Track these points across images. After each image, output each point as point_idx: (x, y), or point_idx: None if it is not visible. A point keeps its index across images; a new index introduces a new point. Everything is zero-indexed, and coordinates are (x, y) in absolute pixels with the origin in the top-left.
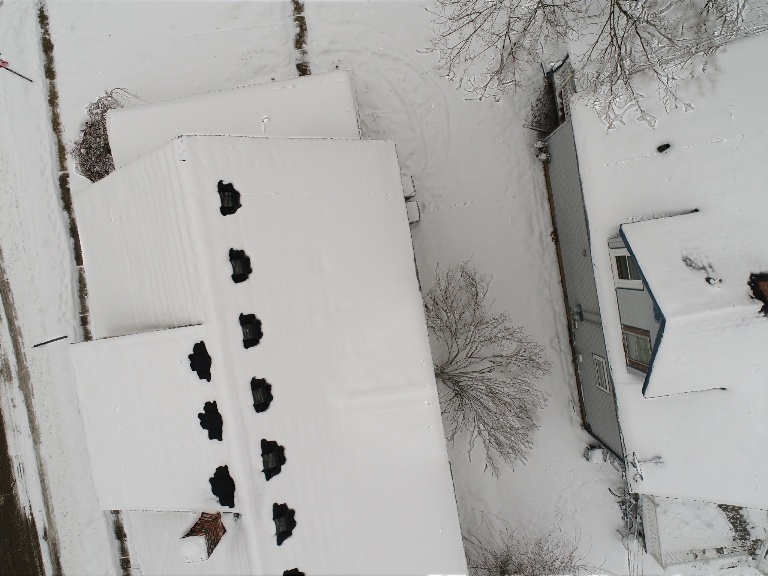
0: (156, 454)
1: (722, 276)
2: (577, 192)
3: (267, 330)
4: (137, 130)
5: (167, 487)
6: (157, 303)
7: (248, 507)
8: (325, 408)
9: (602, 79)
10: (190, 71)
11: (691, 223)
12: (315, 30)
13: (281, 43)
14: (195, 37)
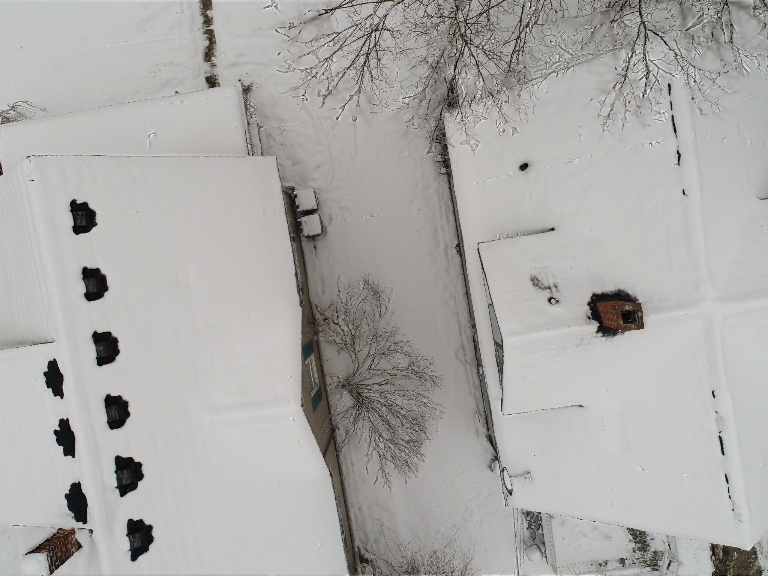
0: (18, 470)
1: (564, 296)
2: None
3: (124, 347)
4: (25, 145)
5: (28, 502)
6: (22, 320)
7: (98, 523)
8: (189, 424)
9: None
10: (100, 84)
11: (544, 242)
12: (223, 43)
13: (190, 56)
14: (104, 50)
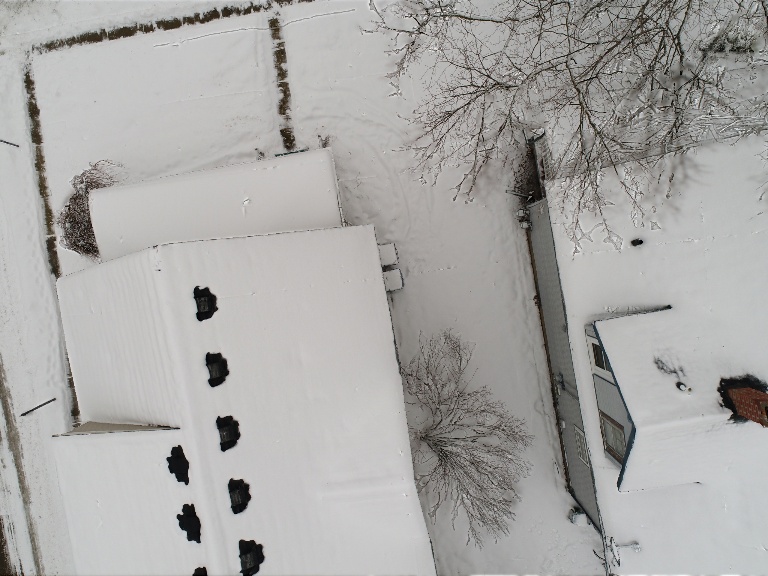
0: (136, 551)
1: (692, 381)
2: (556, 269)
3: (245, 430)
4: (119, 212)
5: None
6: (137, 400)
7: None
8: (304, 502)
9: (573, 185)
10: (175, 138)
11: (663, 322)
12: (298, 96)
13: (265, 109)
14: (179, 104)
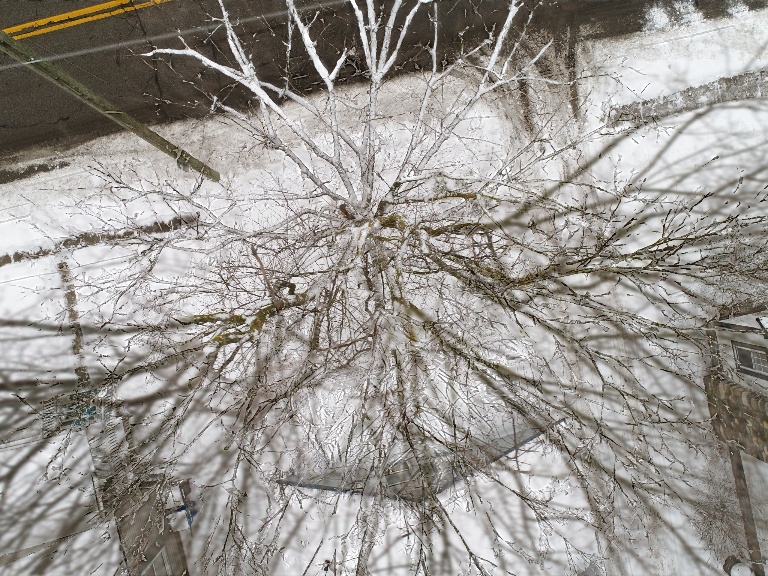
0: None
1: None
2: None
3: None
4: None
5: None
6: None
7: None
8: None
9: None
10: None
11: None
12: (89, 338)
13: (57, 352)
14: None
